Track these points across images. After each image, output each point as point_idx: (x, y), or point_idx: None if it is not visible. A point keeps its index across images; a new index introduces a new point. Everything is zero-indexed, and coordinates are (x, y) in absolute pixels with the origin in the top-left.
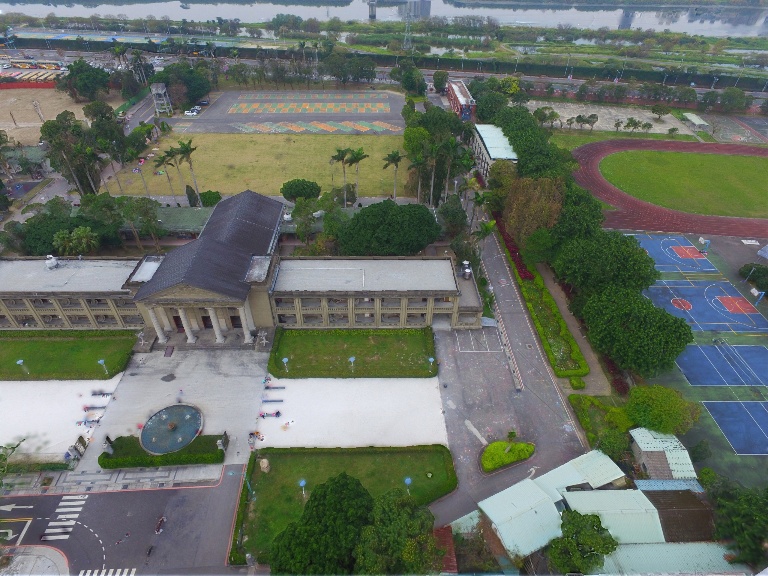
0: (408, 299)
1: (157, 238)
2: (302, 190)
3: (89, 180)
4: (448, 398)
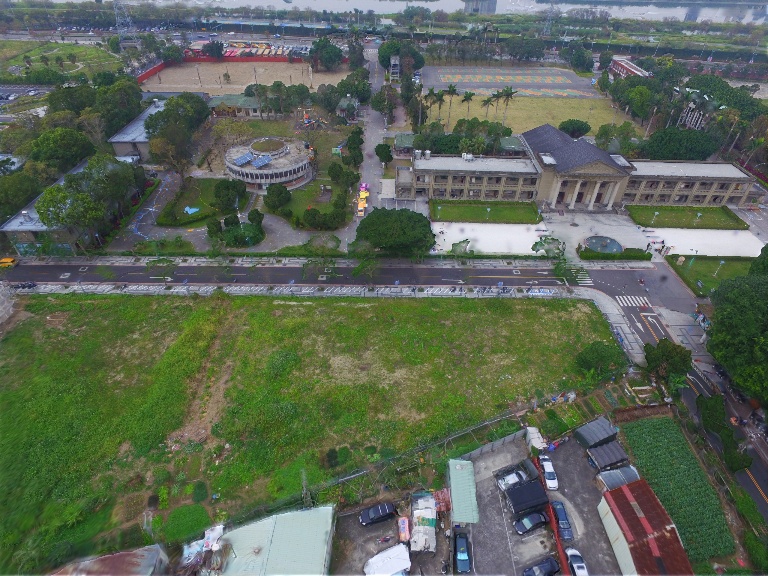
0: None
1: (495, 153)
2: (582, 126)
3: (425, 116)
4: (764, 240)
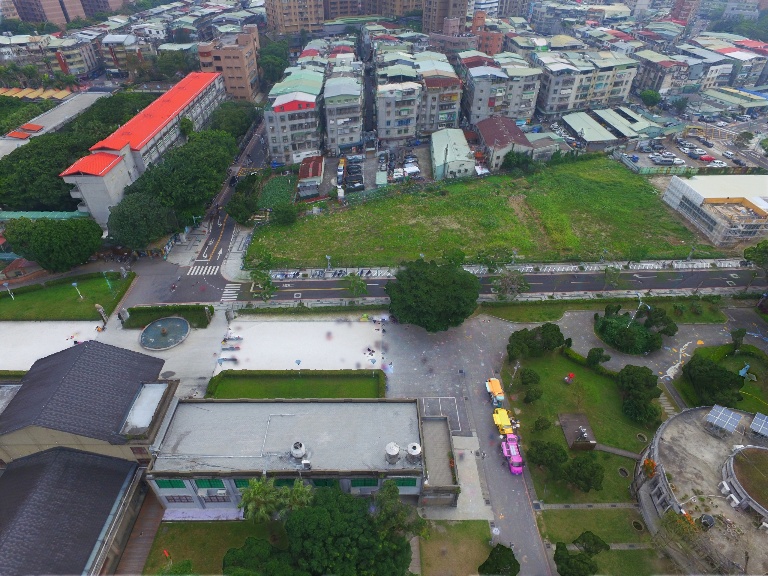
0: None
1: None
2: None
3: None
4: None
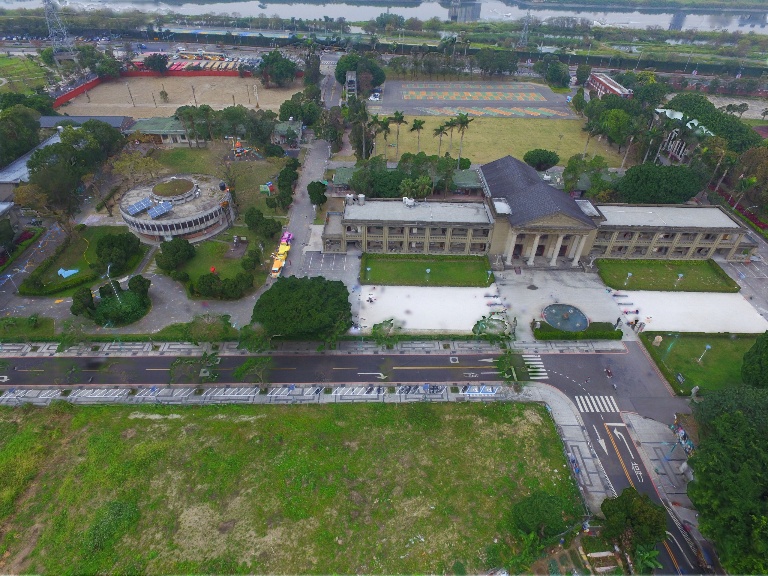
0: None
1: None
2: (549, 157)
3: (371, 146)
4: (758, 306)
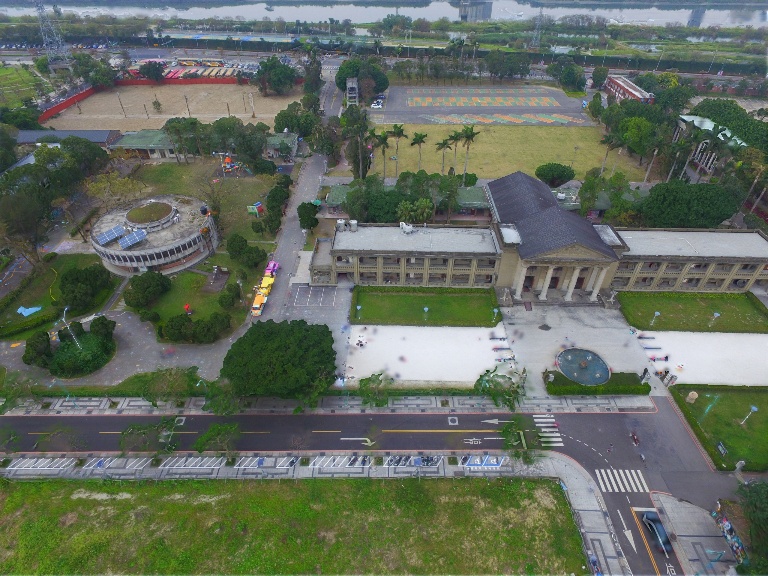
0: None
1: (451, 212)
2: (563, 172)
3: (368, 161)
4: None
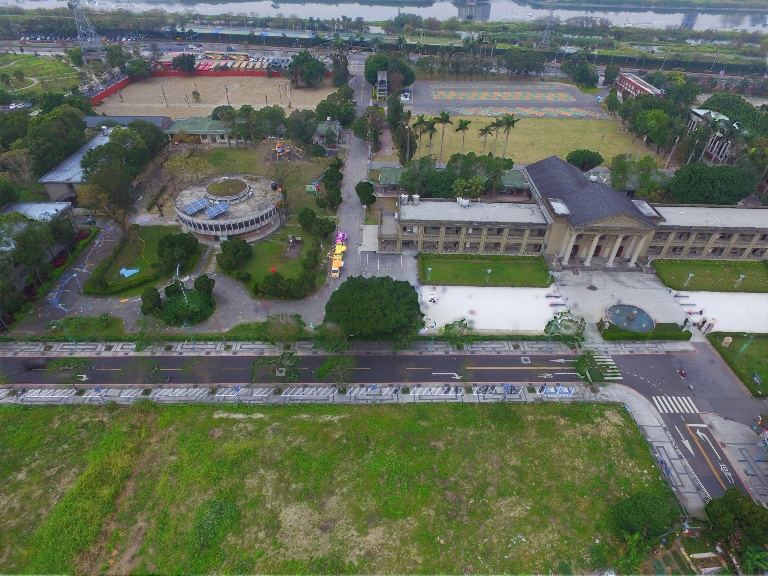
0: (760, 235)
1: None
2: (593, 157)
3: (414, 146)
4: None
